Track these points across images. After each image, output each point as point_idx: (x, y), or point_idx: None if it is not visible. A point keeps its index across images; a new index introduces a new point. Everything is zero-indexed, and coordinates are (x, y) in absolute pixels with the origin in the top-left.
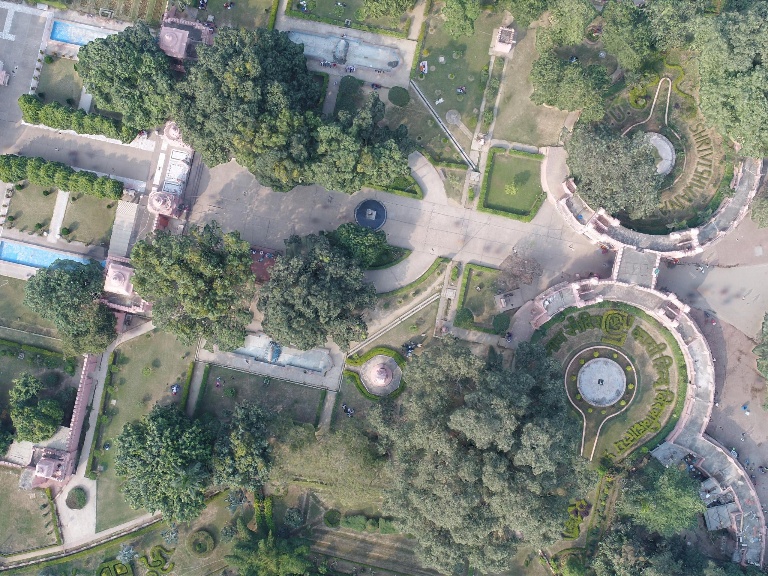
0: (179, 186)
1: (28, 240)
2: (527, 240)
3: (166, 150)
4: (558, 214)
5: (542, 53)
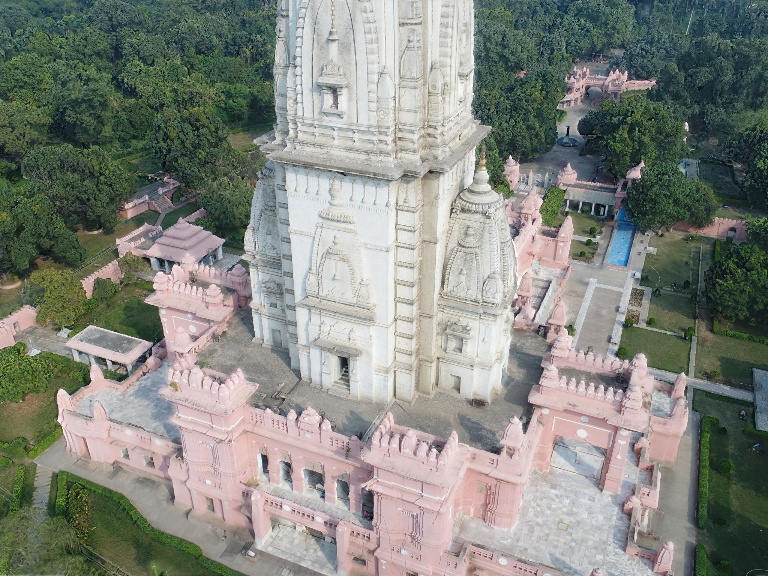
0: (550, 179)
1: (603, 252)
2: (579, 115)
3: (517, 191)
4: (562, 109)
5: (474, 87)
